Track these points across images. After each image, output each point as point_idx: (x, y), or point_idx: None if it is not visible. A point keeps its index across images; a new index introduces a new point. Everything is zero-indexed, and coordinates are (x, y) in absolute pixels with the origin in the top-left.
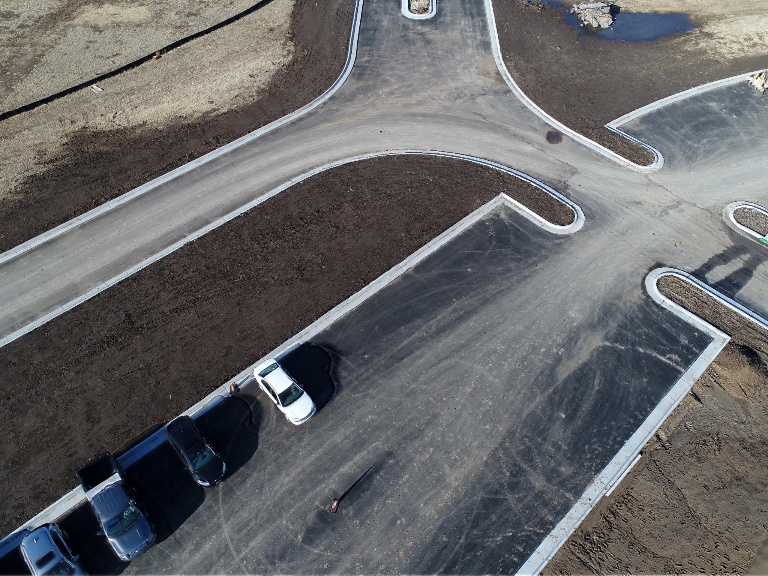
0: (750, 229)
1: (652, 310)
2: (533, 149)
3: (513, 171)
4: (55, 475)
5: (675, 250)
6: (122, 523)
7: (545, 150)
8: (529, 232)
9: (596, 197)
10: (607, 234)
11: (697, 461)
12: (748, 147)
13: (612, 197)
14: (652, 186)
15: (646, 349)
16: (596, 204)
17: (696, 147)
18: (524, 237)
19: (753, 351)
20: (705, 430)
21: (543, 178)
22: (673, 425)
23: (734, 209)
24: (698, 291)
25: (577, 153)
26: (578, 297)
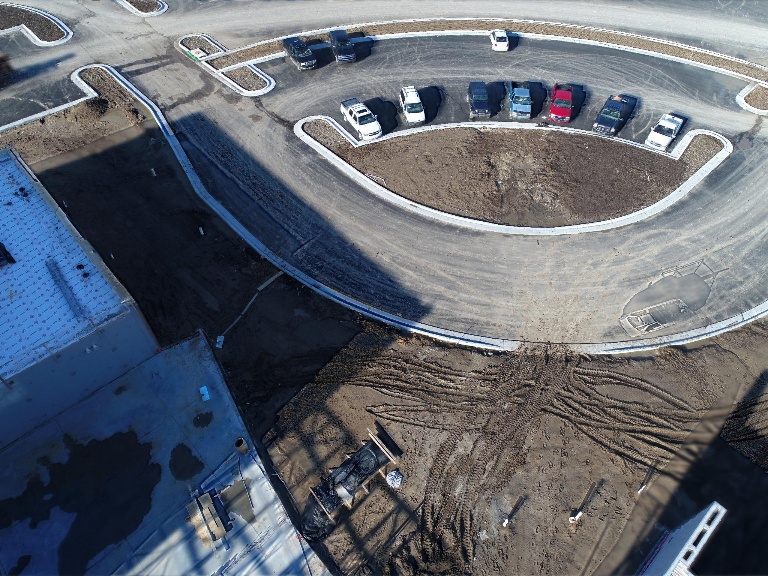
0: (185, 47)
1: (63, 83)
2: (75, 3)
3: (45, 14)
4: None
5: (117, 56)
6: None
7: (84, 4)
8: (21, 45)
9: (92, 29)
10: (78, 47)
11: (5, 145)
12: (239, 5)
13: (105, 29)
14: (142, 24)
15: (35, 100)
16: (88, 32)
17: (199, 4)
18: (15, 47)
19: (106, 101)
20: (29, 134)
21: (64, 18)
22: (12, 132)
23: (186, 37)
24: (106, 75)
25: (106, 6)
26: (19, 76)
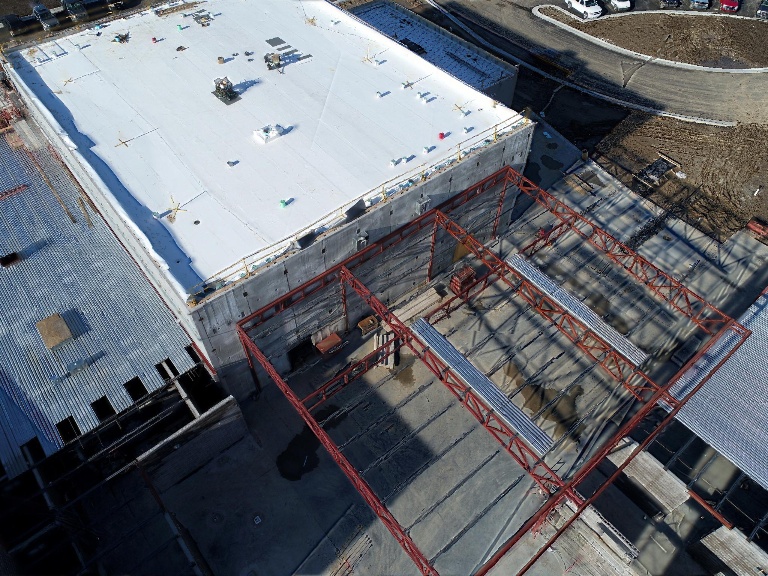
0: None
1: None
2: None
3: None
4: (49, 4)
5: None
6: (75, 7)
7: None
8: None
9: None
10: None
11: None
12: None
13: None
14: None
15: None
16: None
17: None
18: None
19: None
20: None
21: None
22: None
23: None
24: None
25: None
26: None
